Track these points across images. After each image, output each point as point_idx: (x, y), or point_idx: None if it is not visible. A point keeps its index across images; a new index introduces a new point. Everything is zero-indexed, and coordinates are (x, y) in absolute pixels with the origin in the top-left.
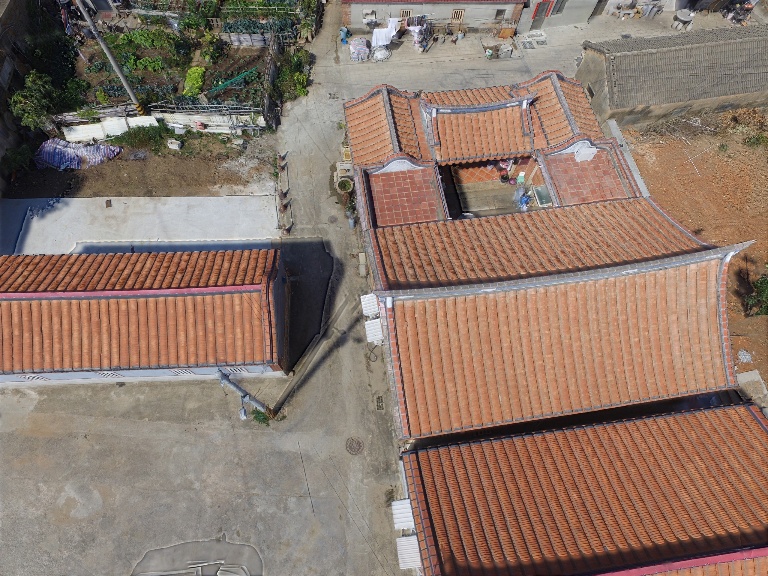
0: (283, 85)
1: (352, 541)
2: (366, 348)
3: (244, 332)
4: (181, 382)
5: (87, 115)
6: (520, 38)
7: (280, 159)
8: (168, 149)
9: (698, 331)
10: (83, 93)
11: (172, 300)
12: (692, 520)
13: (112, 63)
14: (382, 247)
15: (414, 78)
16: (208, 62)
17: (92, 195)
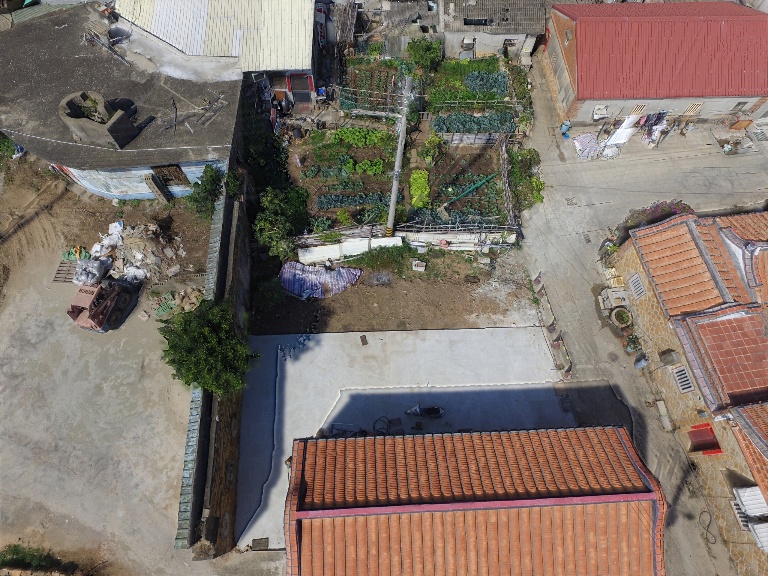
0: (519, 191)
1: None
2: (699, 526)
3: (629, 545)
4: None
5: (330, 237)
6: (750, 128)
7: (538, 282)
8: (412, 271)
9: None
10: (313, 207)
11: (548, 510)
12: None
13: (393, 197)
14: None
15: (652, 179)
16: (428, 163)
17: (342, 329)
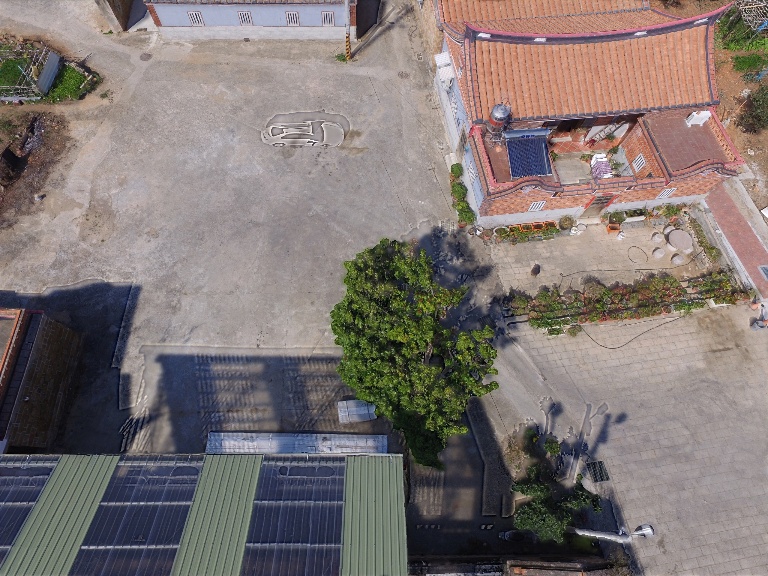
0: None
1: (405, 116)
2: (409, 31)
3: None
4: (287, 40)
5: None
6: None
7: None
8: None
9: None
10: None
11: None
12: None
13: None
14: None
15: None
16: None
17: None
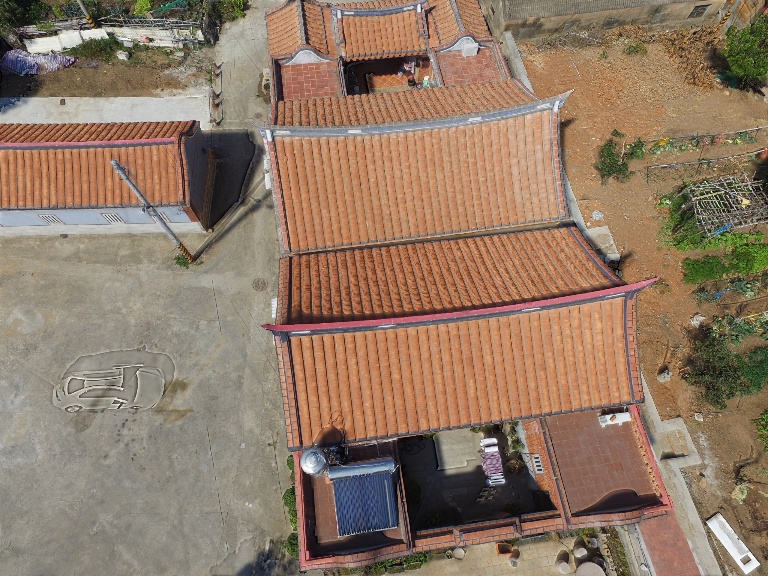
0: (222, 8)
1: (251, 353)
2: None
3: (161, 178)
4: (116, 235)
5: (45, 27)
6: None
7: (215, 67)
8: (117, 59)
9: (536, 173)
10: (43, 12)
11: (101, 151)
12: (499, 293)
13: None
14: (279, 112)
15: None
16: None
17: (49, 96)
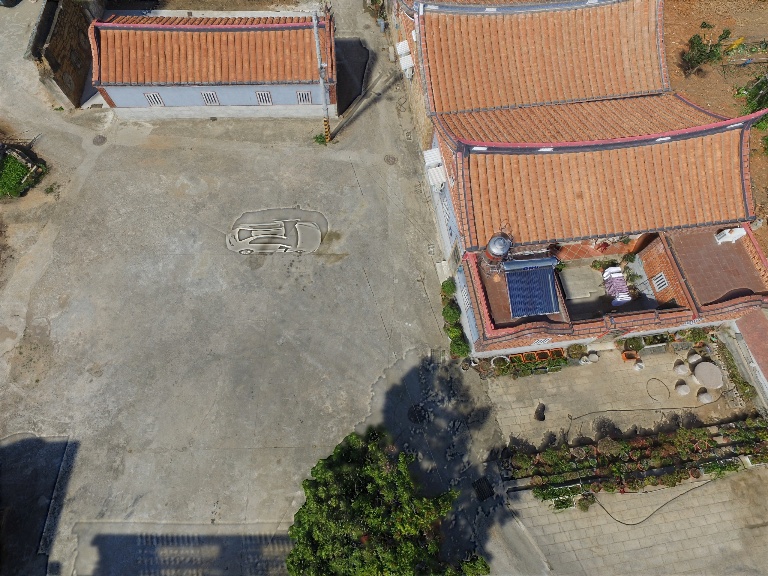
0: None
1: (392, 212)
2: (397, 104)
3: (312, 58)
4: (259, 119)
5: None
6: None
7: None
8: None
9: (642, 51)
10: None
11: (260, 34)
12: None
13: None
14: (412, 3)
15: None
16: None
17: (176, 9)
